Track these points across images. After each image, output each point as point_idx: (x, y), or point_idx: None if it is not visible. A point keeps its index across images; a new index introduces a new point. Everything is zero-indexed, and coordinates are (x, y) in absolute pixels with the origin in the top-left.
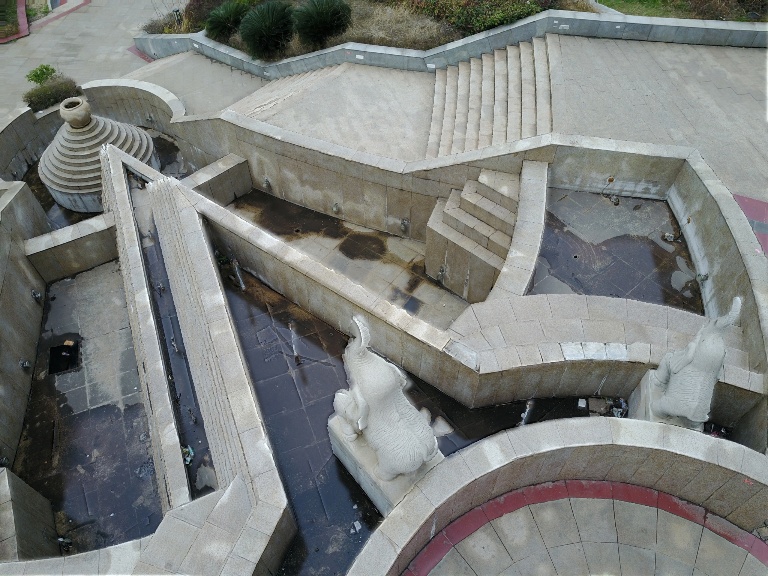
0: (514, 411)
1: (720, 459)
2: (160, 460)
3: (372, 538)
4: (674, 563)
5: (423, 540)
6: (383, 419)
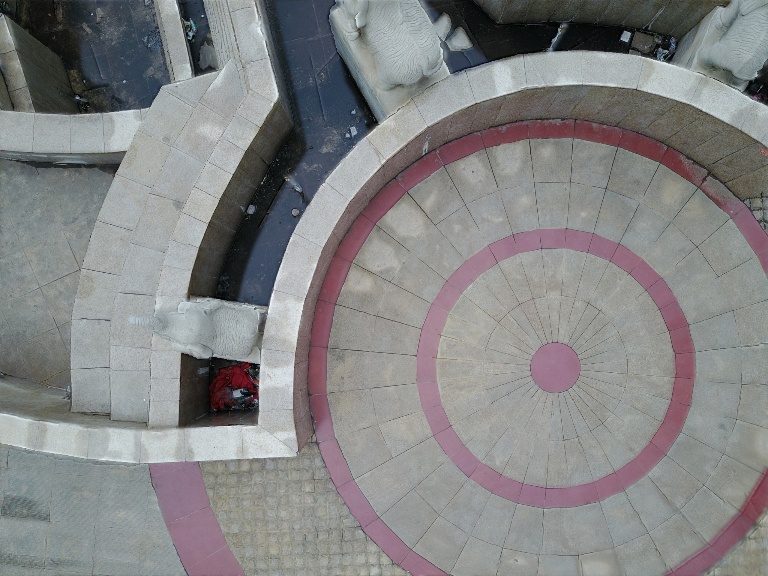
0: (546, 34)
1: (746, 124)
2: (163, 31)
3: (359, 145)
4: (653, 215)
5: (414, 155)
6: (384, 19)
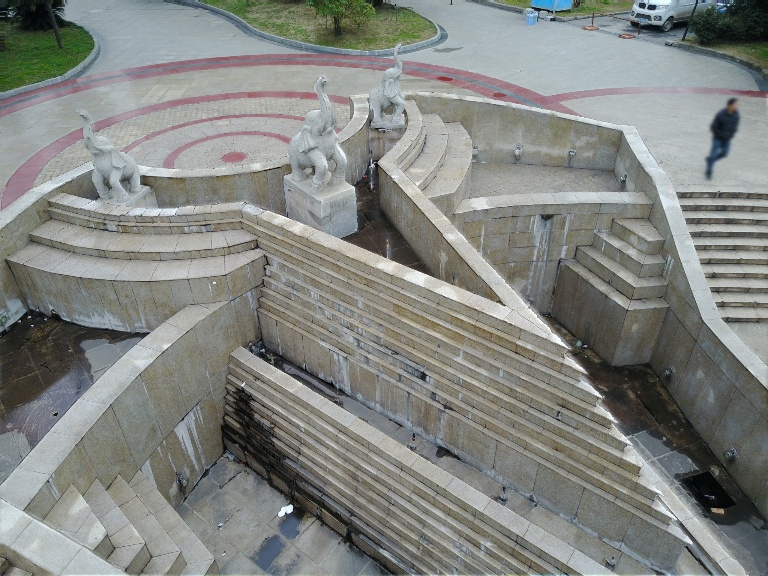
0: None
1: None
2: None
3: None
4: None
5: None
6: None
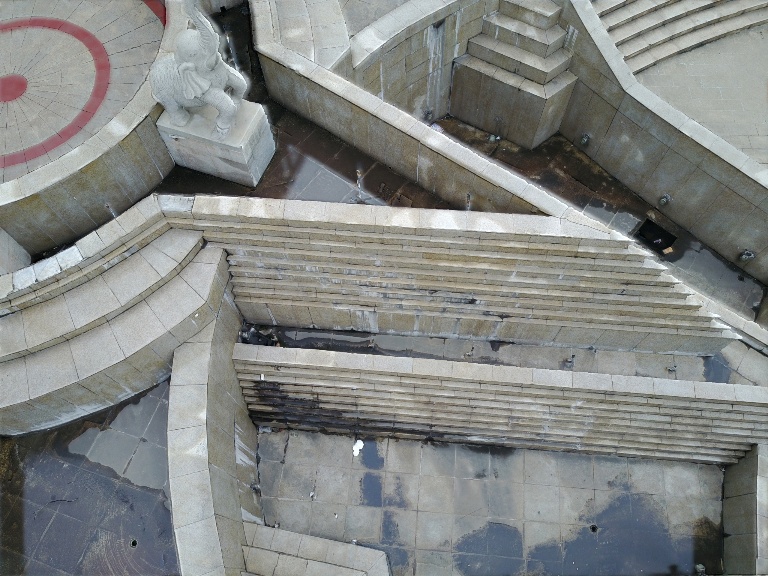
0: None
1: None
2: None
3: None
4: None
5: None
6: None
